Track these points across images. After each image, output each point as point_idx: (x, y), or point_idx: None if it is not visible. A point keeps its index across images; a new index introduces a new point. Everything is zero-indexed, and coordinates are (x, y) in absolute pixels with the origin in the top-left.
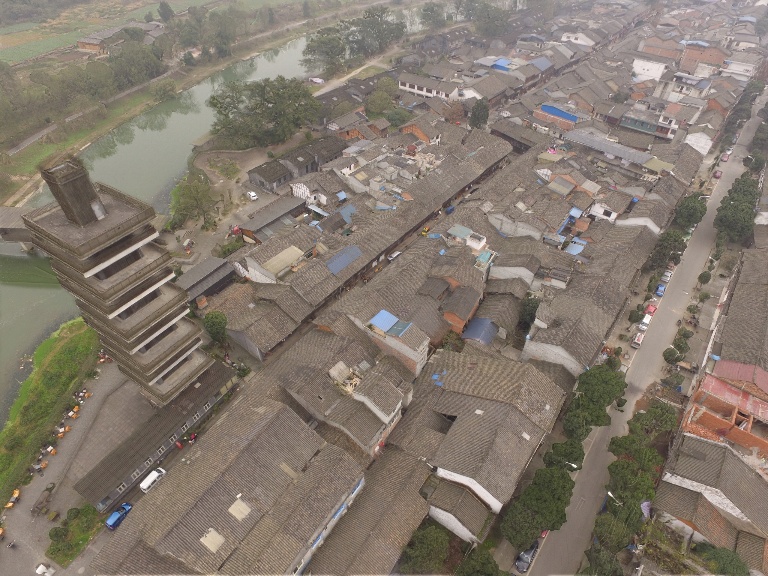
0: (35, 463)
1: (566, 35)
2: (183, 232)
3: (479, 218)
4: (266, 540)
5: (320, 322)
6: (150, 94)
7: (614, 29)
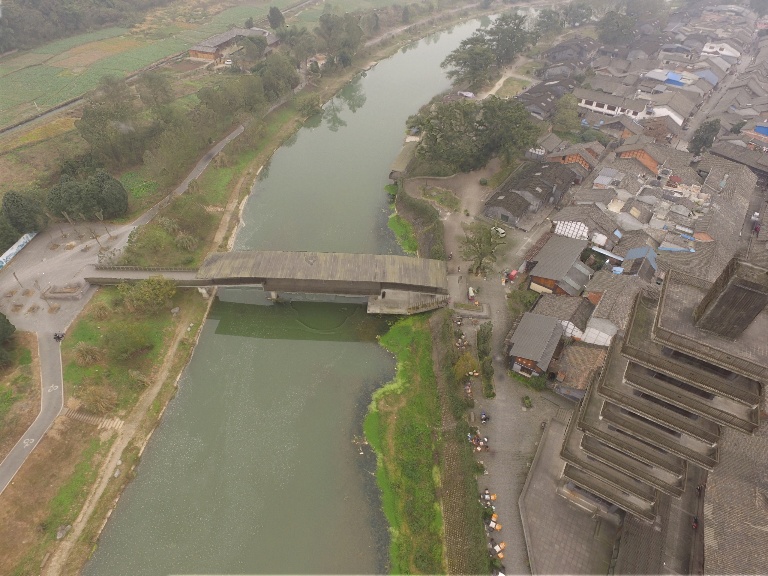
0: None
1: (709, 45)
2: (455, 278)
3: None
4: None
5: None
6: (294, 109)
7: (746, 38)
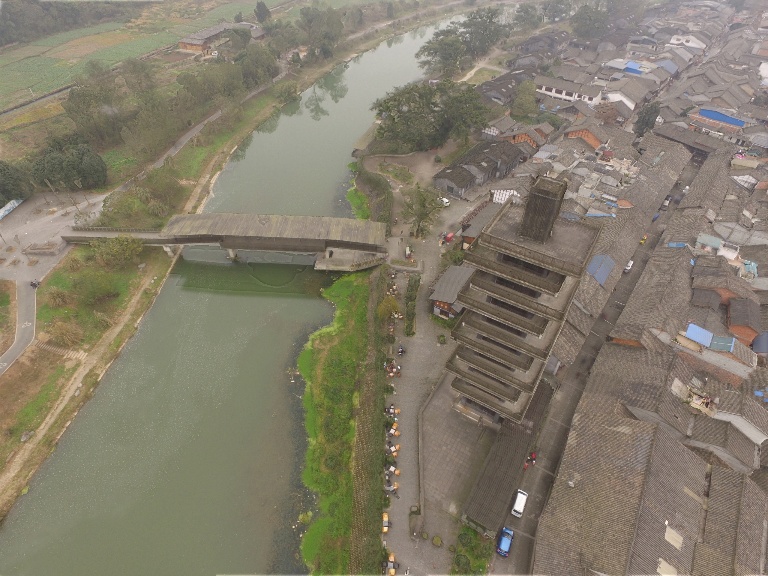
0: (386, 484)
1: (676, 37)
2: (396, 239)
3: (706, 226)
4: (725, 571)
5: (621, 336)
6: (272, 96)
7: (716, 31)
